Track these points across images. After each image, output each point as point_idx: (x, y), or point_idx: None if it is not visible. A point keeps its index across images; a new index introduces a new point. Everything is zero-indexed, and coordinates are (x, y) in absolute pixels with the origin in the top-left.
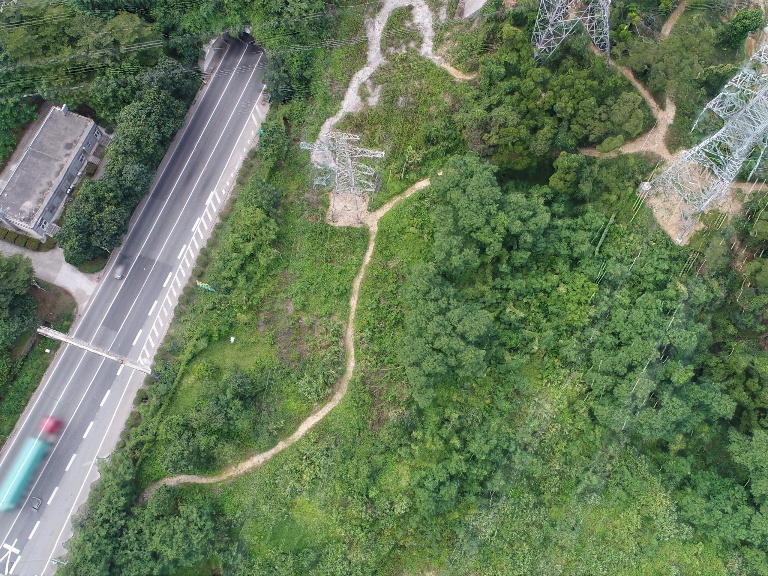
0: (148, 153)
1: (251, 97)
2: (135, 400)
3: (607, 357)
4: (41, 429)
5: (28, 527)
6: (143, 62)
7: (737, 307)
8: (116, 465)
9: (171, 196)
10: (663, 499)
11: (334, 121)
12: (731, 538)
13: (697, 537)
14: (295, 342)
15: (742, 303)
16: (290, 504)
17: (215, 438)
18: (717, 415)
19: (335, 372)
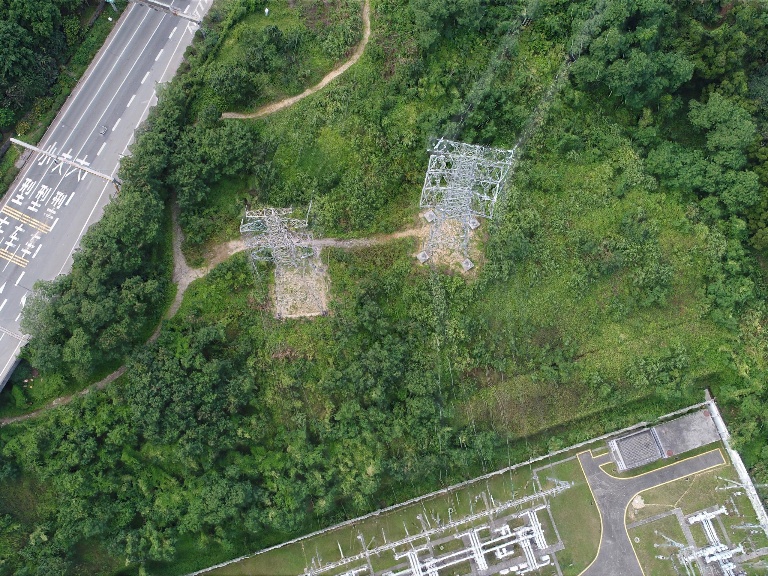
0: None
1: None
2: (185, 53)
3: None
4: (106, 77)
5: (96, 147)
6: None
7: None
8: (172, 86)
9: None
10: (632, 154)
11: None
12: (689, 184)
13: (661, 190)
14: (320, 15)
15: None
16: (316, 134)
17: (253, 73)
18: (679, 82)
19: (354, 32)
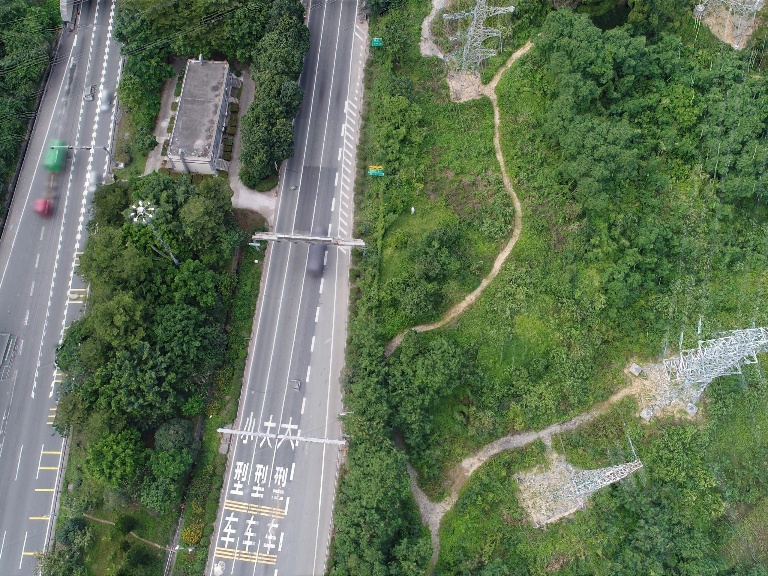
0: (295, 72)
1: (349, 20)
2: (351, 278)
3: (721, 141)
4: (276, 325)
5: (297, 405)
6: (262, 1)
7: None
8: (366, 323)
9: (312, 113)
10: None
11: (430, 19)
12: None
13: None
14: (465, 199)
15: None
16: (511, 325)
17: (436, 283)
18: None
19: None
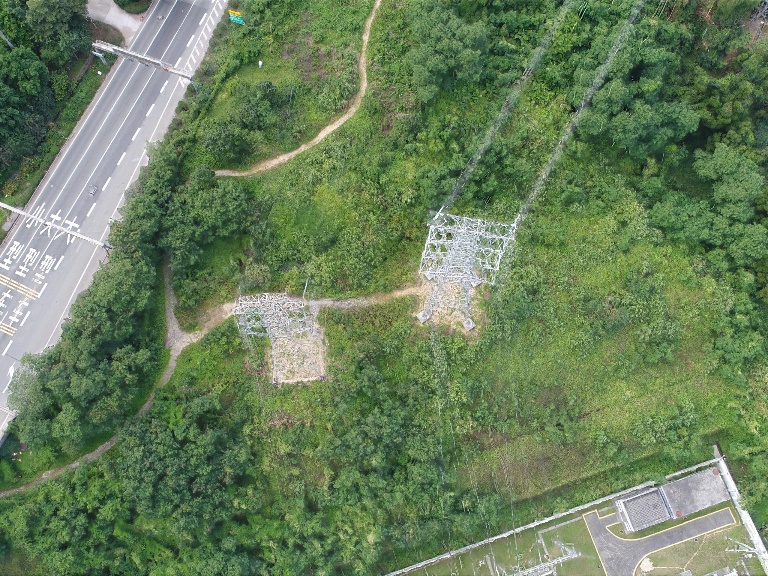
0: None
1: None
2: (177, 109)
3: None
4: (95, 134)
5: (86, 208)
6: None
7: (704, 51)
8: (163, 146)
9: None
10: (636, 206)
11: None
12: (696, 237)
13: (667, 243)
14: (315, 67)
15: (707, 40)
16: (312, 192)
17: (247, 130)
18: (684, 132)
19: (350, 86)
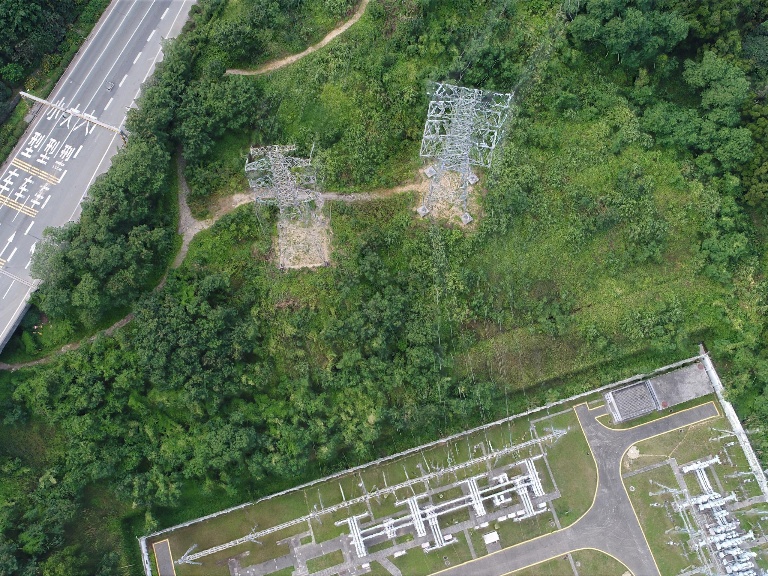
0: None
1: None
2: (190, 12)
3: None
4: (112, 35)
5: (104, 102)
6: None
7: None
8: (177, 41)
9: None
10: (628, 112)
11: None
12: (684, 141)
13: (656, 148)
14: None
15: None
16: (318, 90)
17: (257, 30)
18: (674, 41)
19: None
